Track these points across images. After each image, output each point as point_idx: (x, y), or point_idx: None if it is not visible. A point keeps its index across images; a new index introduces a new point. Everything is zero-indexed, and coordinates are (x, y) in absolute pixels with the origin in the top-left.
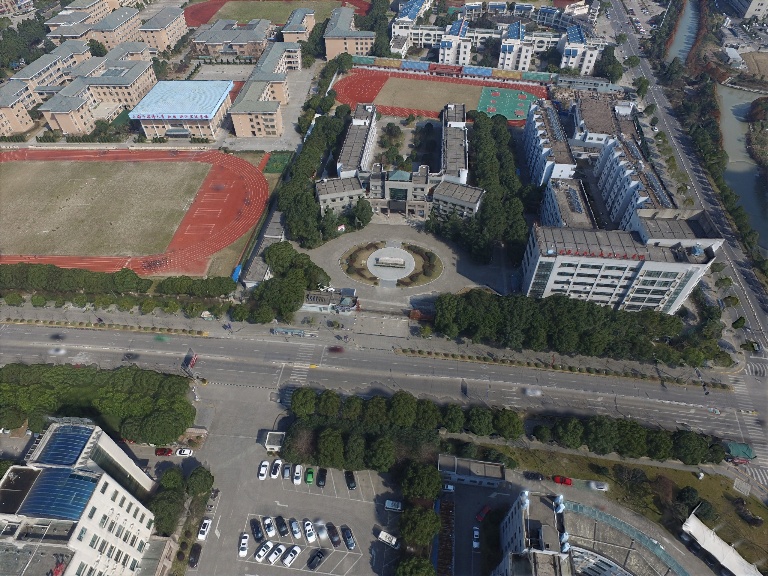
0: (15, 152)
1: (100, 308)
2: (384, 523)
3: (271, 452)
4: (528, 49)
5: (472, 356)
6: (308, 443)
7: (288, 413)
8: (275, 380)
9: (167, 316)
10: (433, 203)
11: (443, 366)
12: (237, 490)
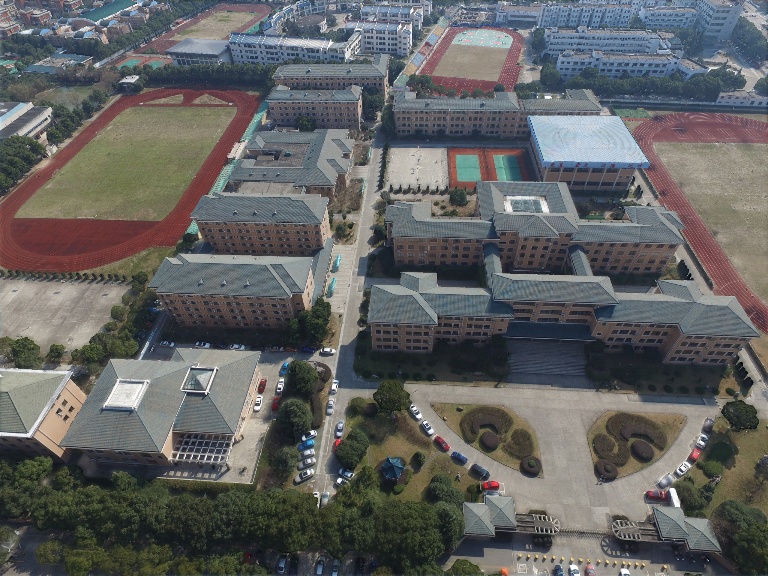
0: None
1: None
2: None
3: None
4: (422, 10)
5: None
6: None
7: None
8: None
9: None
10: None
11: None
12: None
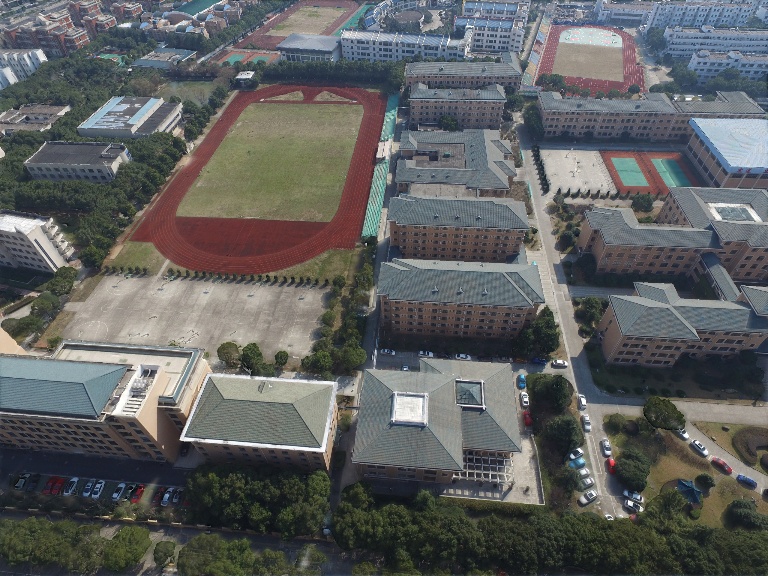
0: None
1: None
2: None
3: None
4: None
5: None
6: None
7: None
8: None
9: None
10: None
11: None
12: None
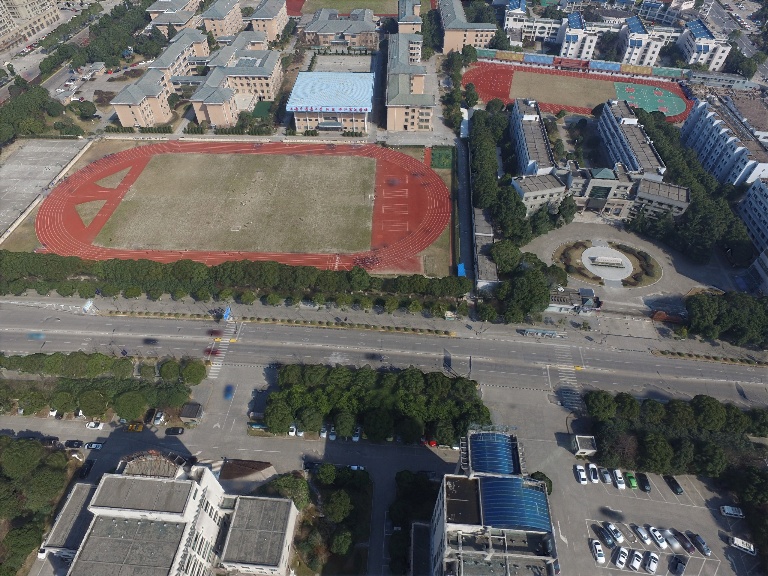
0: (167, 144)
1: (332, 307)
2: (727, 529)
3: (580, 456)
4: (657, 44)
5: (734, 358)
6: (634, 448)
7: (576, 416)
8: (546, 382)
9: (405, 315)
10: (635, 202)
11: (709, 368)
12: (563, 495)
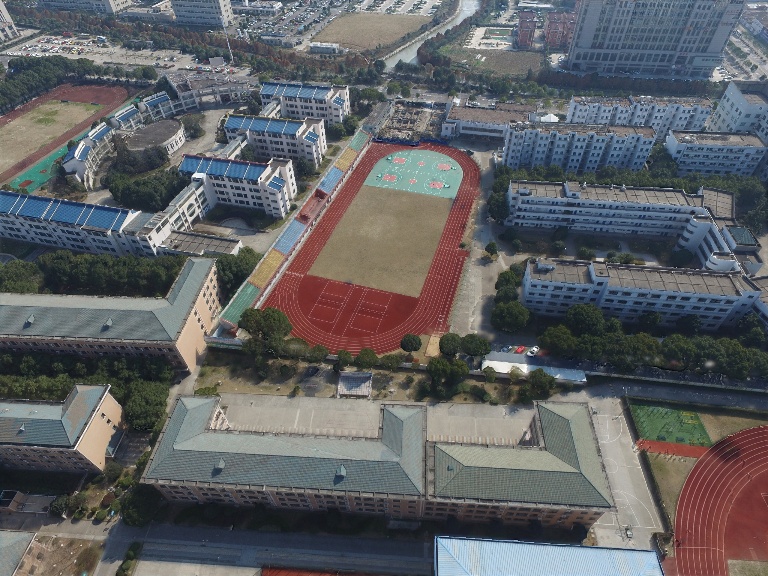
0: None
1: None
2: None
3: None
4: (321, 124)
5: None
6: None
7: None
8: None
9: None
10: None
11: None
12: None
